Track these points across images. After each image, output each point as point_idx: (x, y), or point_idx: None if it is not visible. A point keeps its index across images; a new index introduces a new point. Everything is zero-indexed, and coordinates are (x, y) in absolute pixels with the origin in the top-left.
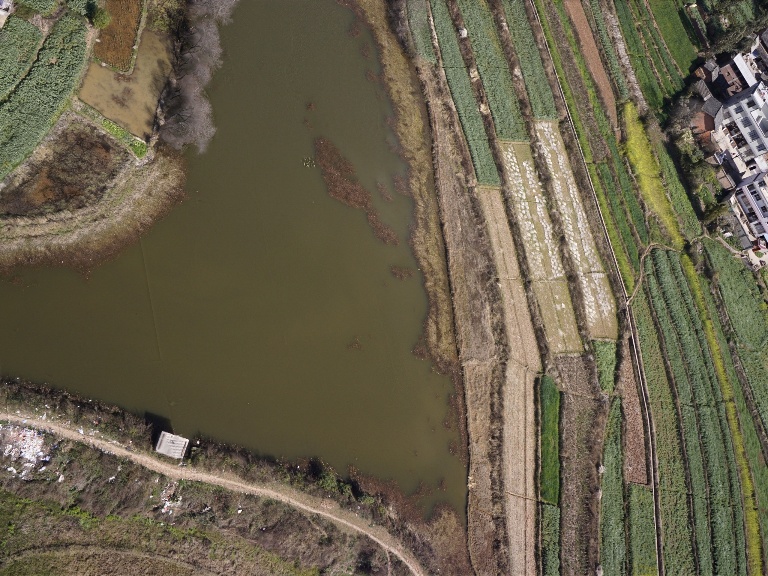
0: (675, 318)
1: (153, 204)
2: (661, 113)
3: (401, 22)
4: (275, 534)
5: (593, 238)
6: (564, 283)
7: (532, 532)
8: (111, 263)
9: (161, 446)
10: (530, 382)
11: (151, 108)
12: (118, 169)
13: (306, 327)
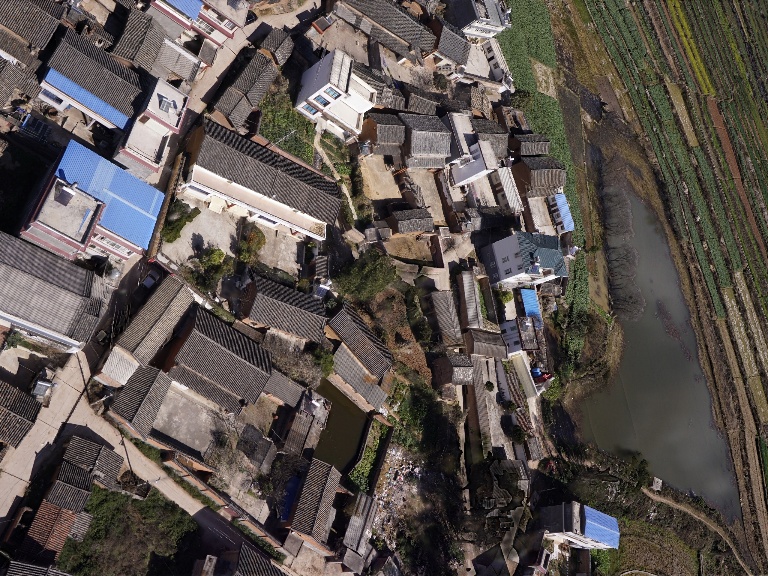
0: None
1: (618, 351)
2: None
3: (671, 216)
4: (687, 530)
5: (767, 347)
6: (759, 378)
7: None
8: (614, 387)
9: (654, 484)
10: (754, 441)
11: (607, 295)
12: (606, 334)
13: (674, 415)
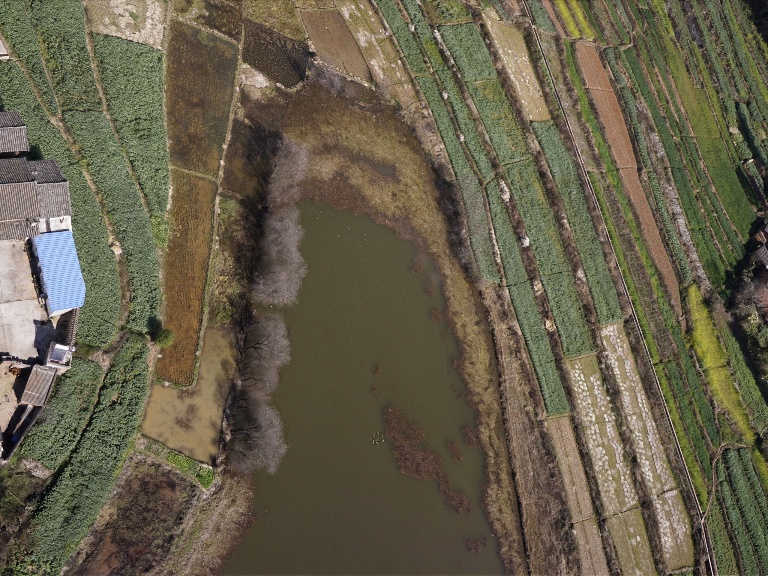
0: (750, 528)
1: (222, 541)
2: (724, 289)
3: (463, 243)
4: None
5: (664, 450)
6: (638, 511)
7: None
8: None
9: None
10: None
11: (216, 422)
12: (185, 510)
13: None
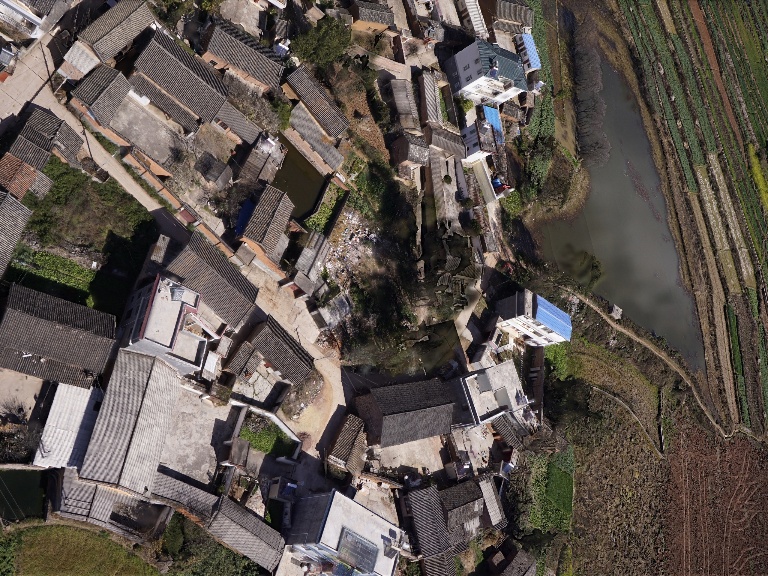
0: None
1: (584, 193)
2: (765, 151)
3: (645, 91)
4: (647, 364)
5: (740, 227)
6: (730, 253)
7: (733, 388)
8: (577, 221)
9: (614, 311)
10: (722, 308)
11: (574, 142)
12: (572, 174)
13: (639, 263)
